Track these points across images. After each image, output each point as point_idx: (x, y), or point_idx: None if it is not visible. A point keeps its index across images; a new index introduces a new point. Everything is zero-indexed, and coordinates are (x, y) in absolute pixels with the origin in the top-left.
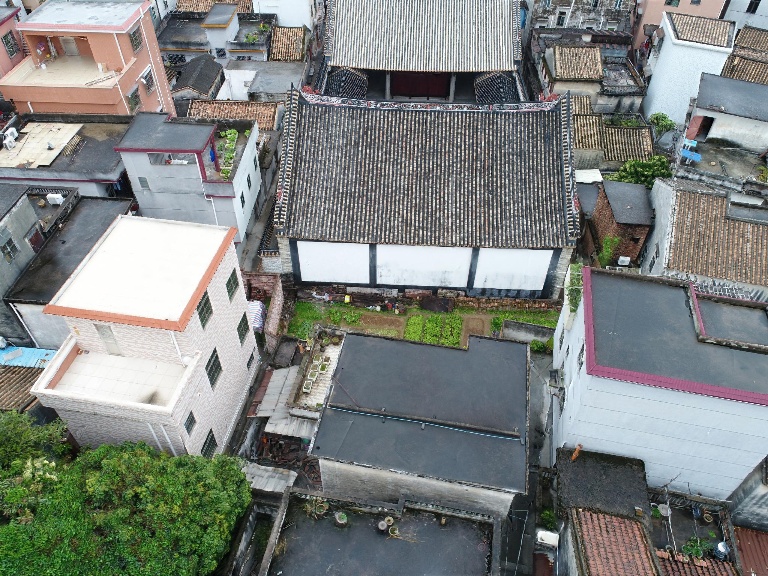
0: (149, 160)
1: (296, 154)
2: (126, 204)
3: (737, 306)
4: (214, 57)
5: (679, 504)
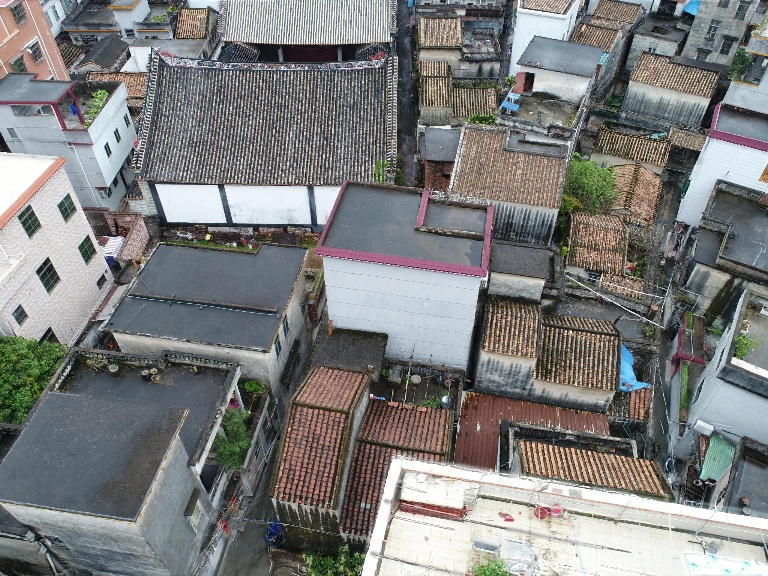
0: (13, 112)
1: (157, 110)
2: None
3: (464, 208)
4: (121, 36)
5: (429, 375)
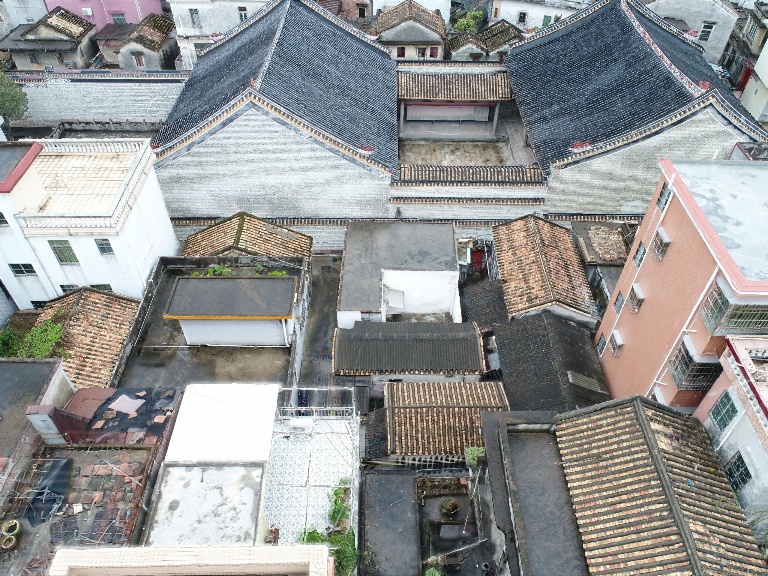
0: None
1: None
2: None
3: None
4: None
5: None
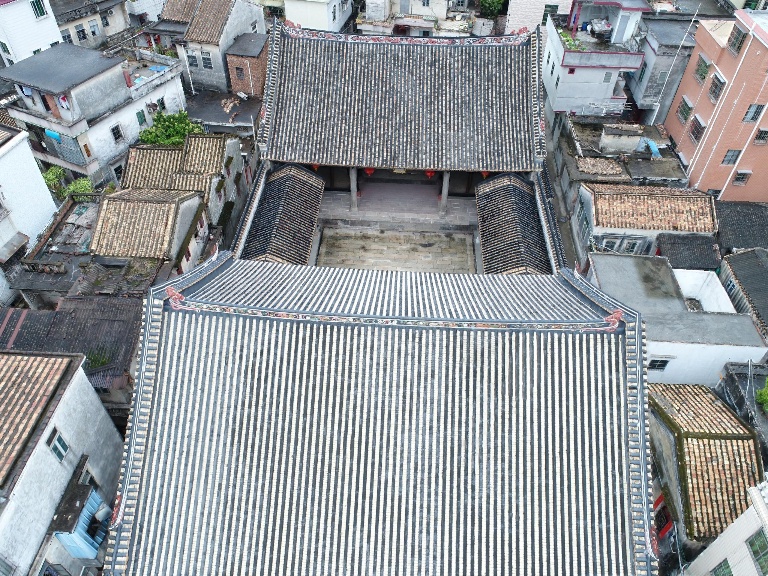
0: None
1: None
2: None
3: None
4: None
5: None
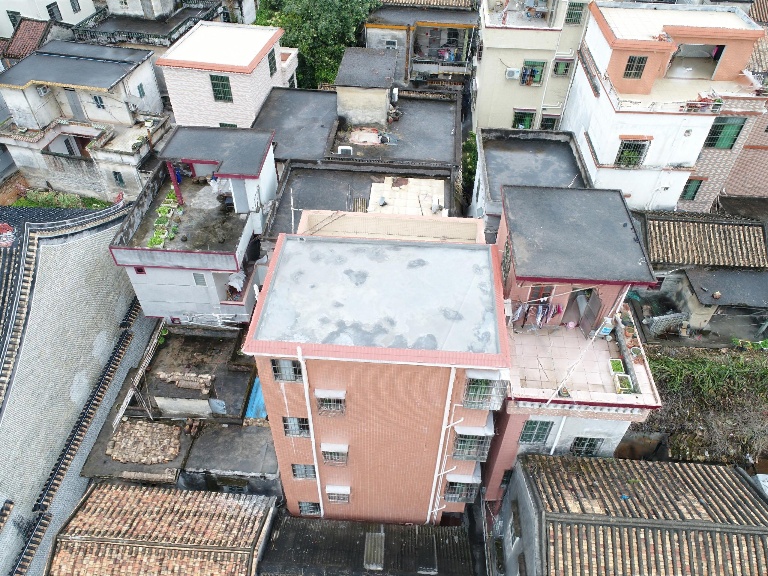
0: None
1: None
2: (277, 155)
3: None
4: None
5: None
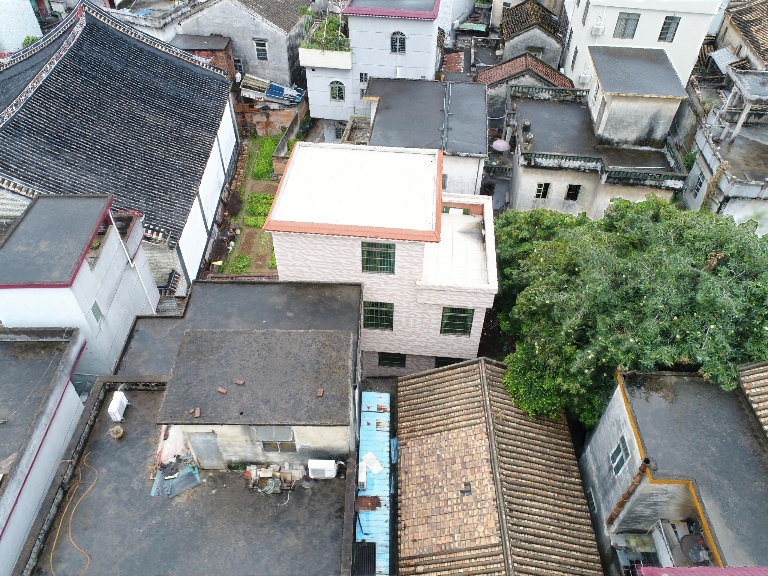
0: (88, 267)
1: None
2: (146, 323)
3: None
4: None
5: None
